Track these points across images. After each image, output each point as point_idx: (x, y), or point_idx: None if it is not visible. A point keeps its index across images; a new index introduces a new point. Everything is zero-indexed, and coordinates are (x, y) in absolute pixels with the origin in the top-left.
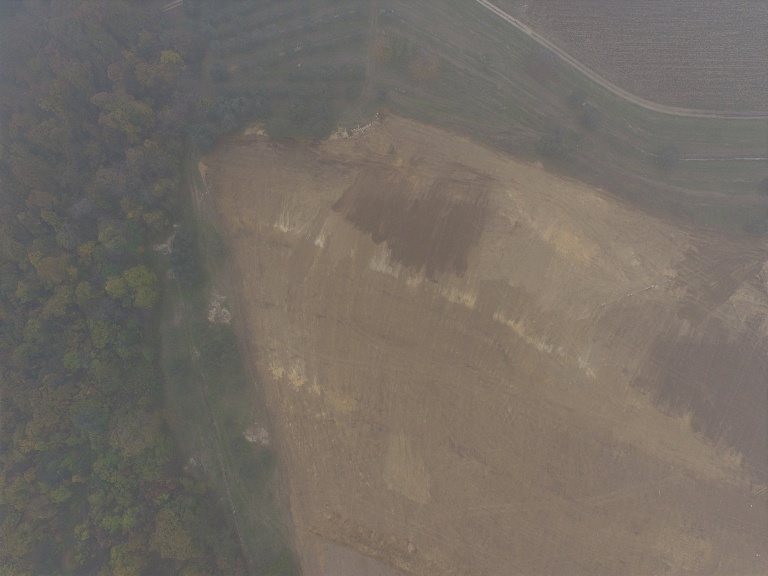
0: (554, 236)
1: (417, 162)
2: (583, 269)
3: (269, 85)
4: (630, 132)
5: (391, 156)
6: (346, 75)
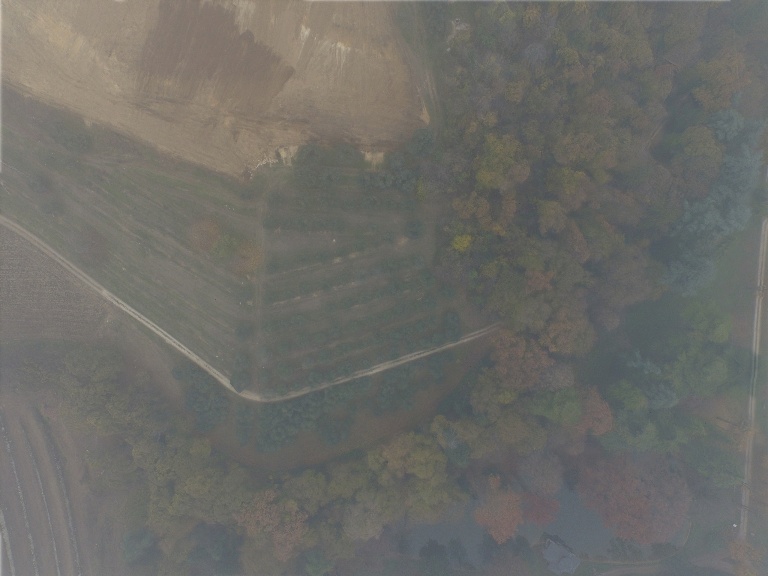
0: (73, 41)
1: (210, 122)
2: (44, 5)
3: (365, 219)
4: (2, 176)
5: (236, 128)
6: (282, 219)
